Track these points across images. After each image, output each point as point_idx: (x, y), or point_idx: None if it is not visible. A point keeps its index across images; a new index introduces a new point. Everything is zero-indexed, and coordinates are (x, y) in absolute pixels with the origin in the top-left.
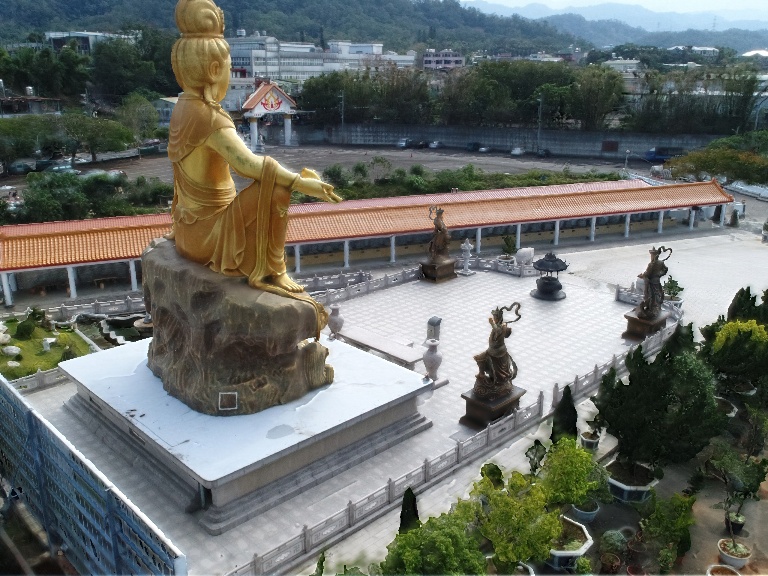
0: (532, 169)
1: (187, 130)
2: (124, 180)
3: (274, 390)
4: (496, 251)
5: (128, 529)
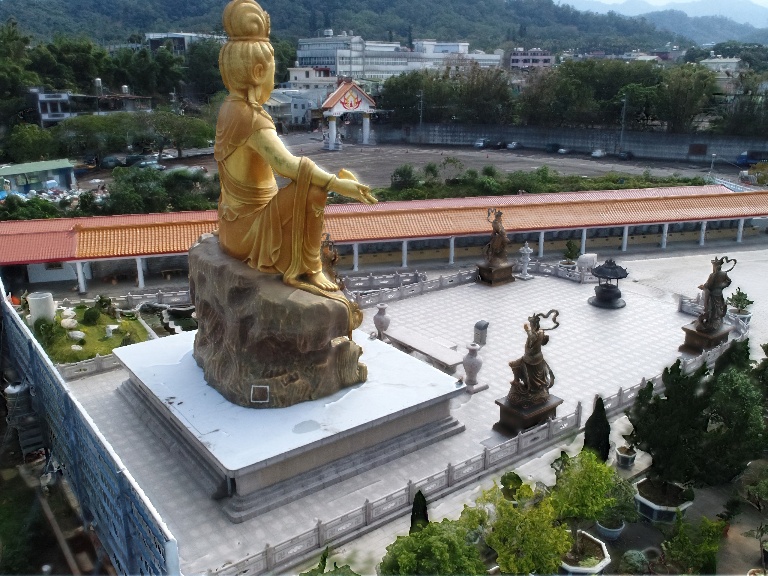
0: (610, 172)
1: (230, 130)
2: (202, 176)
3: (305, 386)
4: (559, 256)
5: (136, 510)
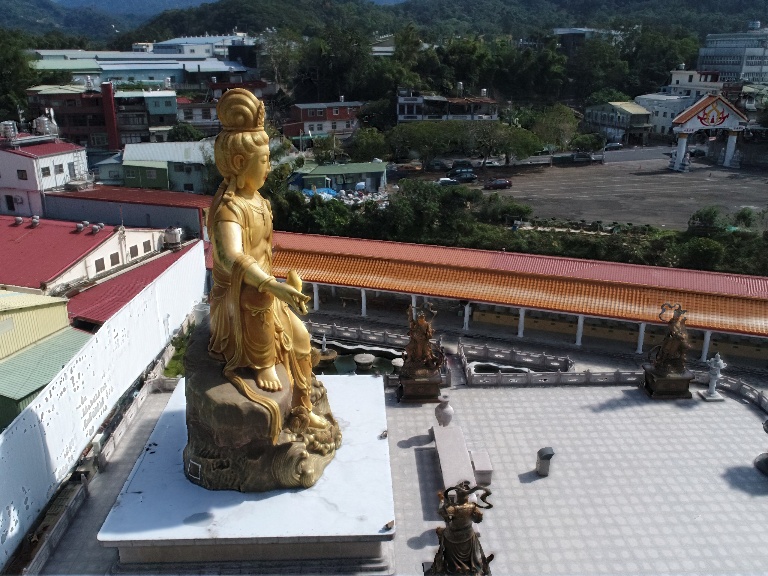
0: None
1: None
2: (478, 195)
3: (234, 475)
4: None
5: None
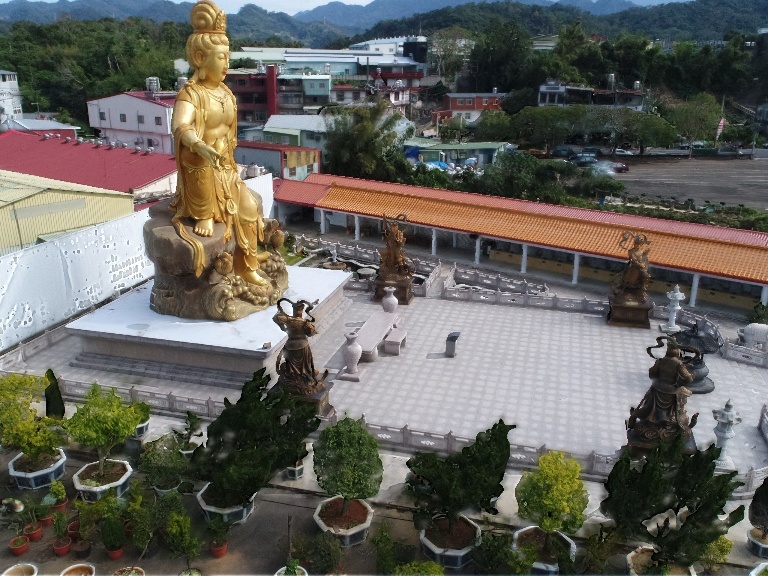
0: None
1: None
2: (571, 169)
3: (175, 303)
4: None
5: None
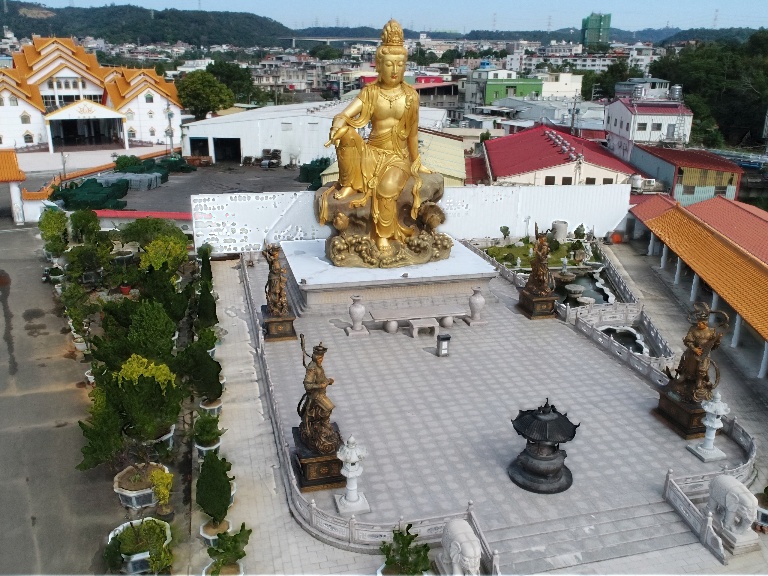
0: None
1: None
2: None
3: None
4: None
5: None
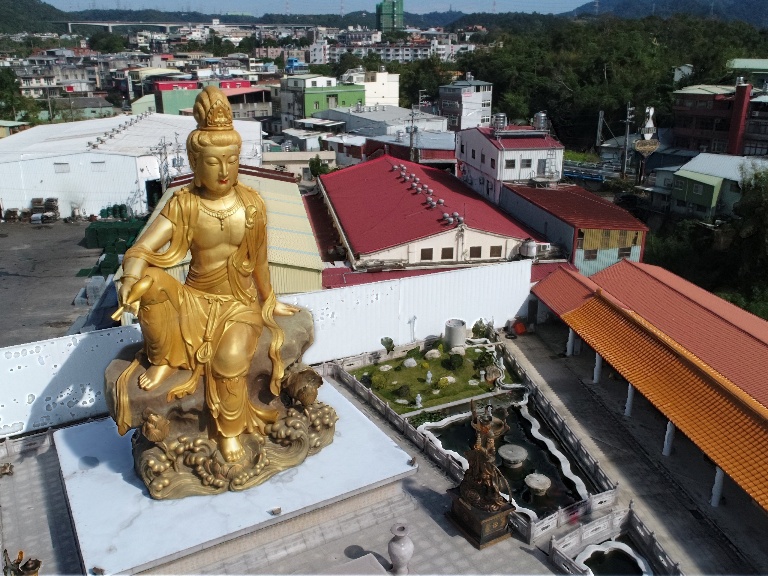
0: None
1: None
2: None
3: None
4: None
5: None
